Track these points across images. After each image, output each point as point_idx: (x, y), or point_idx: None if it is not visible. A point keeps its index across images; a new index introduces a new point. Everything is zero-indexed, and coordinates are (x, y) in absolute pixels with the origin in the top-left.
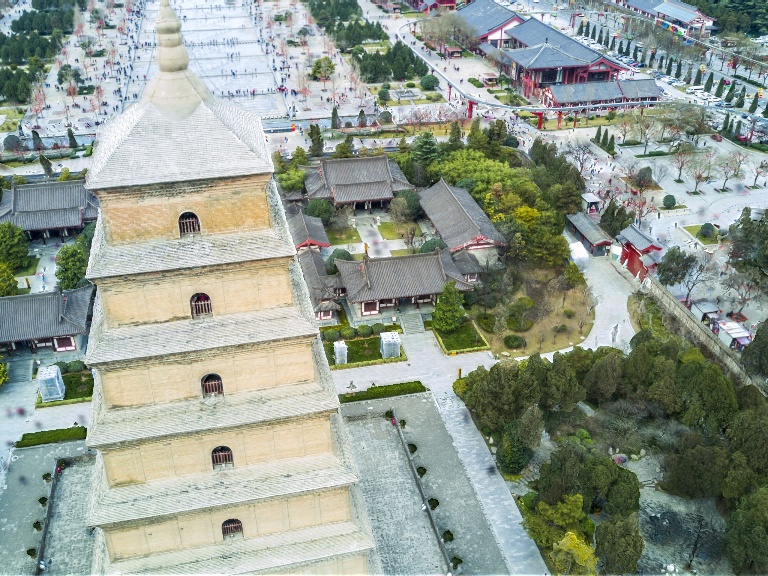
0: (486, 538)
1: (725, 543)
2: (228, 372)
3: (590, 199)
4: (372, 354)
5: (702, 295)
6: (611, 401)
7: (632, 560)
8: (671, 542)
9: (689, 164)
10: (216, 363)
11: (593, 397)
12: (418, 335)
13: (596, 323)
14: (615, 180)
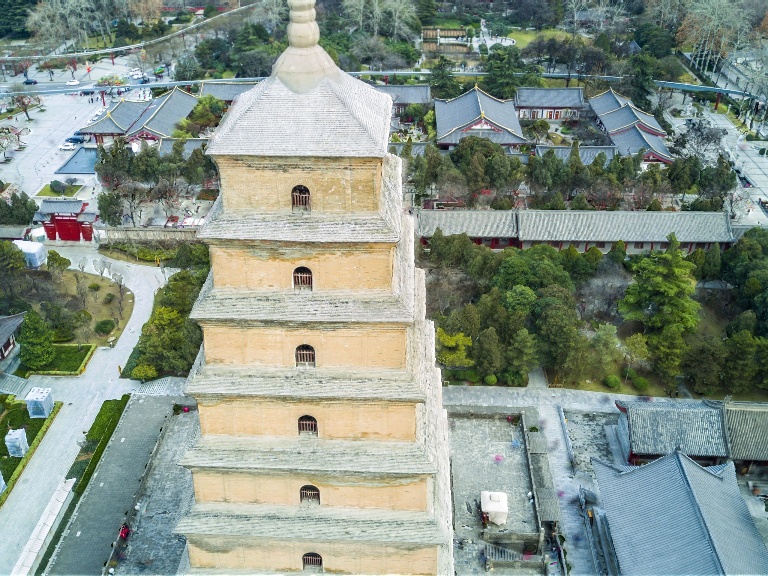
0: None
1: None
2: None
3: None
4: (31, 425)
5: (148, 216)
6: None
7: None
8: None
9: None
10: None
11: None
12: (29, 387)
13: None
14: None
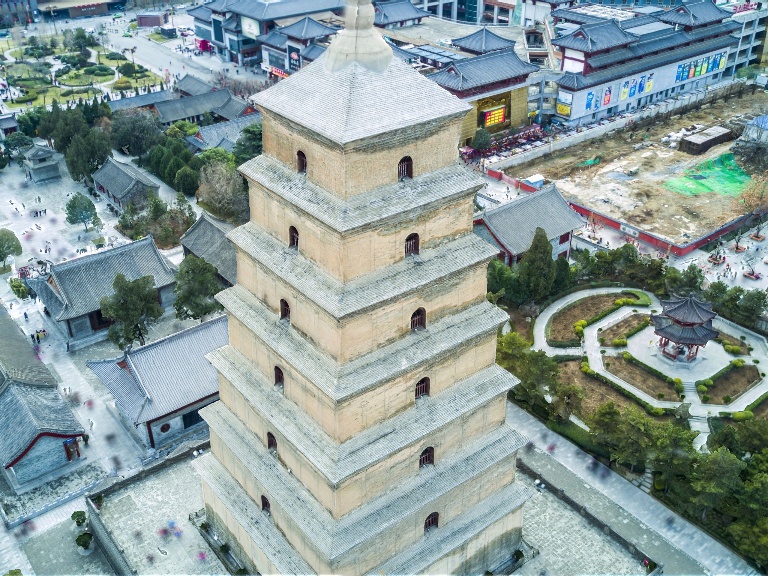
0: None
1: None
2: None
3: None
4: None
5: None
6: None
7: None
8: None
9: None
10: None
11: None
12: None
13: None
14: None
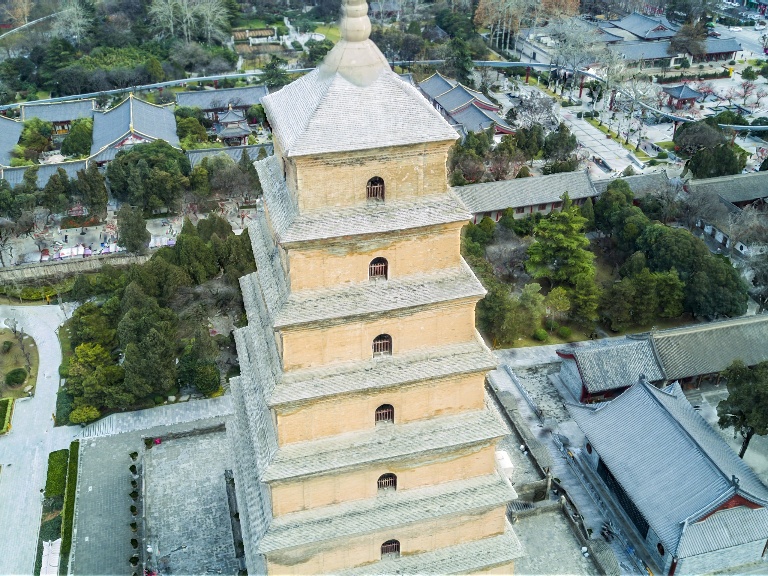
0: None
1: None
2: None
3: None
4: None
5: None
6: None
7: None
8: None
9: None
10: None
11: None
12: None
13: (7, 326)
14: None
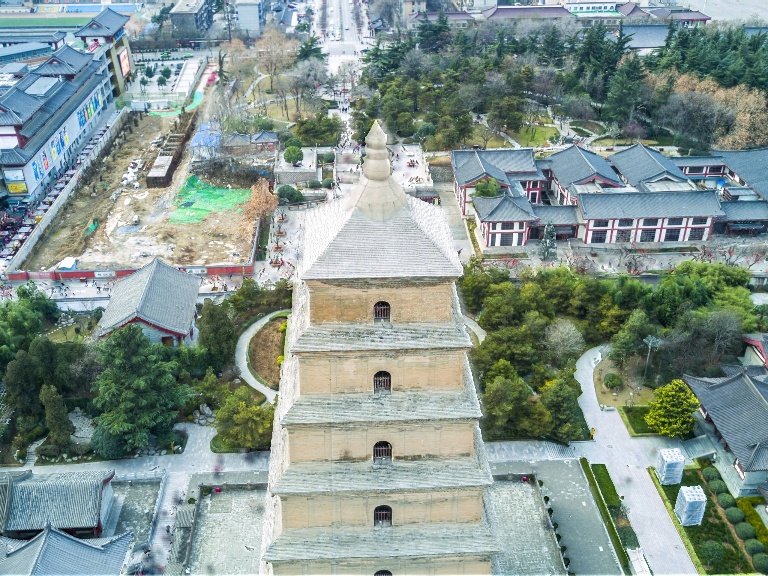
0: None
1: None
2: None
3: None
4: None
5: None
6: None
7: None
8: None
9: None
10: None
11: None
12: None
13: None
14: None
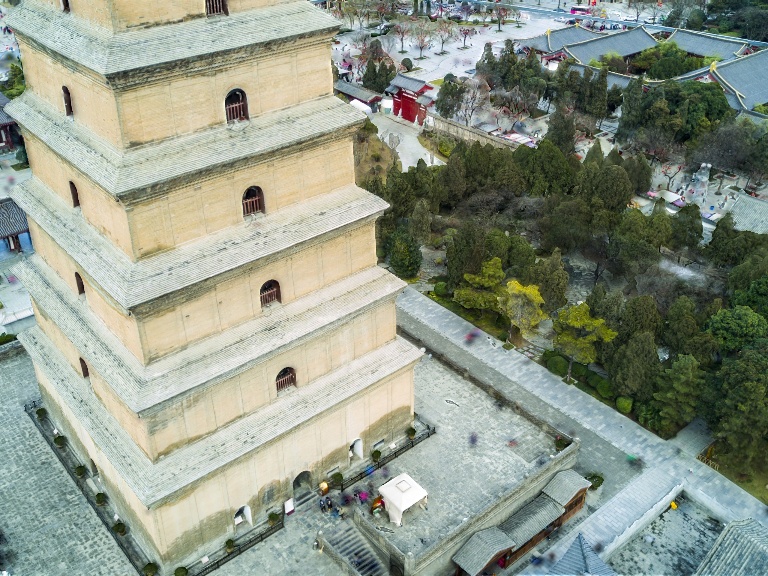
0: (421, 329)
1: (620, 263)
2: (253, 86)
3: (340, 71)
4: None
5: (481, 119)
6: (464, 200)
7: (562, 293)
8: (568, 288)
9: (409, 33)
10: (241, 73)
11: (445, 203)
12: None
13: (403, 160)
14: (348, 59)
